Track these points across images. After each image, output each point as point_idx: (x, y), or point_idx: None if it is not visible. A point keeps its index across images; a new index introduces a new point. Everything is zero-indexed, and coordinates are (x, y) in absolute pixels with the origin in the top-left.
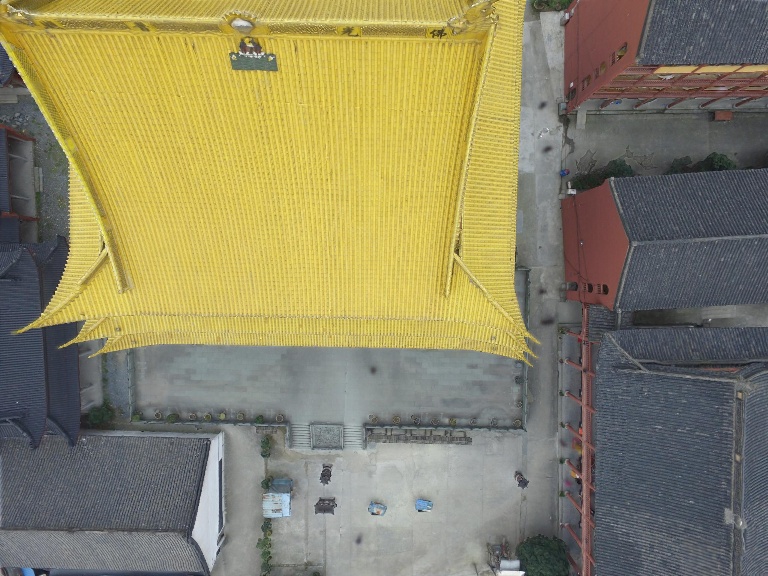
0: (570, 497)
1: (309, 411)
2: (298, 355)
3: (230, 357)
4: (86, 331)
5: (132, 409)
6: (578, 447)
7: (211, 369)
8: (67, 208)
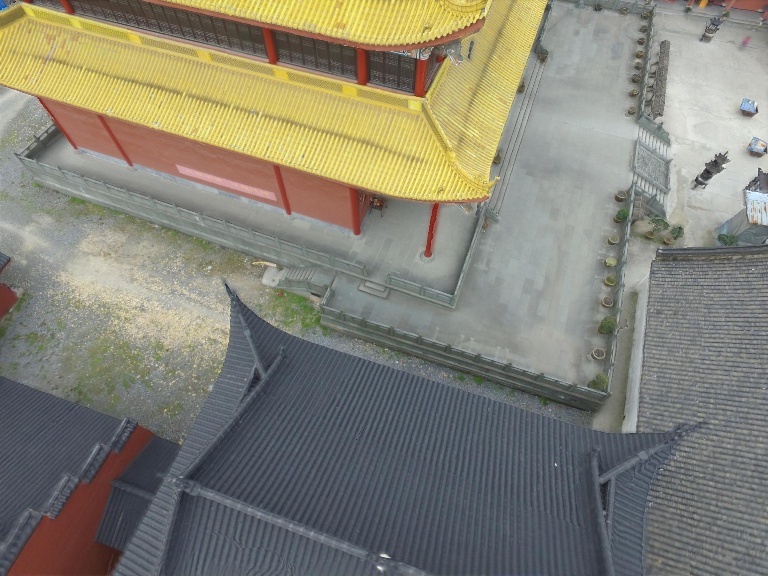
0: (730, 3)
1: (613, 168)
2: (531, 159)
3: (516, 231)
4: (467, 0)
5: (582, 389)
6: (673, 0)
7: (530, 259)
8: (185, 402)
